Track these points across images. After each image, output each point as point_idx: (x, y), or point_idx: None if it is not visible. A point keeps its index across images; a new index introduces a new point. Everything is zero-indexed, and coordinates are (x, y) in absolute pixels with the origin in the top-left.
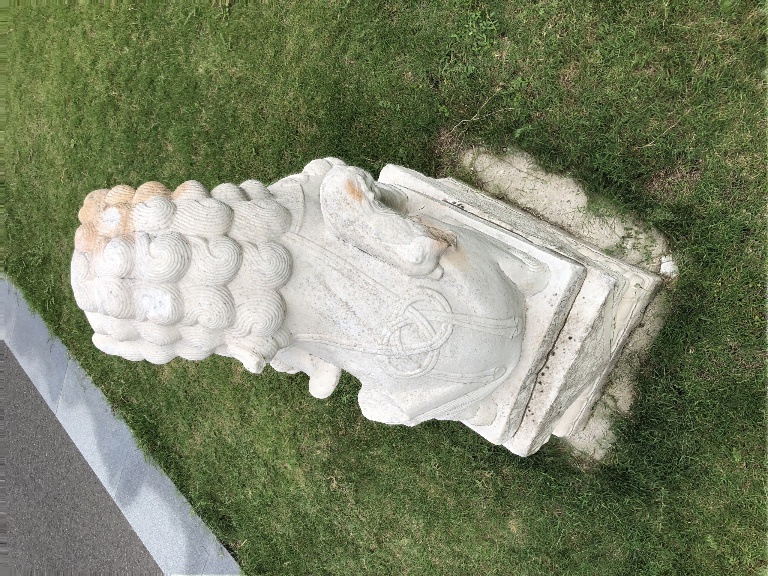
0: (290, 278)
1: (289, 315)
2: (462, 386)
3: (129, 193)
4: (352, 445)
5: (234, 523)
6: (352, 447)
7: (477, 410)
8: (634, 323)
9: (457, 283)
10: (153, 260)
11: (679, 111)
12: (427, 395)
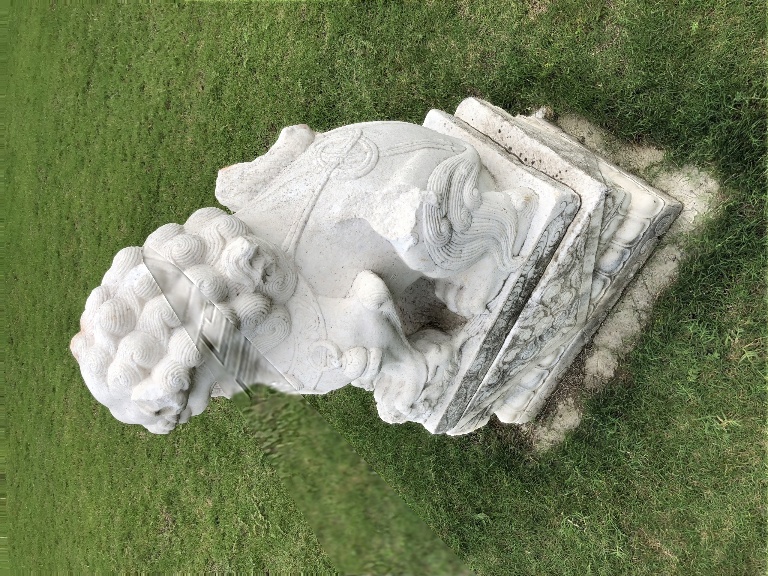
0: None
1: (254, 229)
2: None
3: None
4: (688, 573)
5: None
6: (692, 575)
7: (505, 193)
8: None
9: (339, 130)
10: (114, 262)
11: None
12: (406, 167)
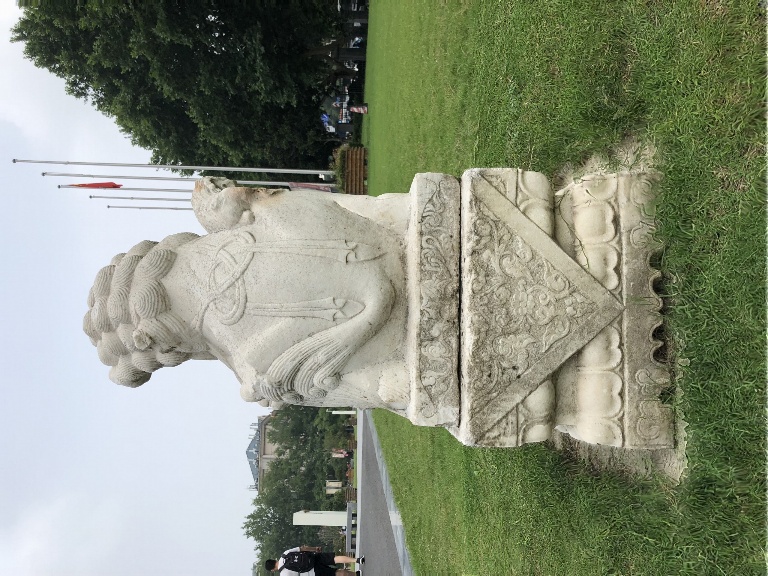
0: (170, 270)
1: (173, 301)
2: (292, 321)
3: None
4: None
5: None
6: None
7: (379, 378)
8: (644, 243)
9: (263, 219)
10: None
11: (609, 0)
12: (260, 338)
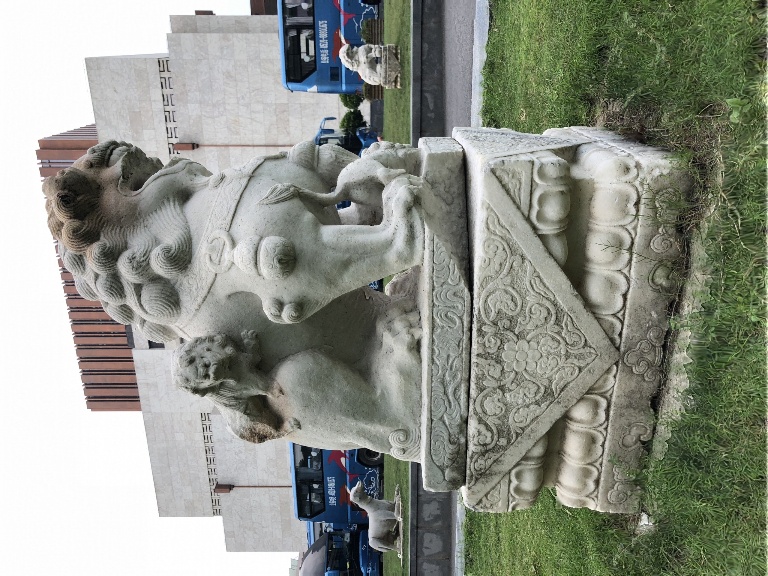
0: None
1: None
2: None
3: (62, 217)
4: None
5: (499, 4)
6: None
7: None
8: None
9: None
10: None
11: None
12: None
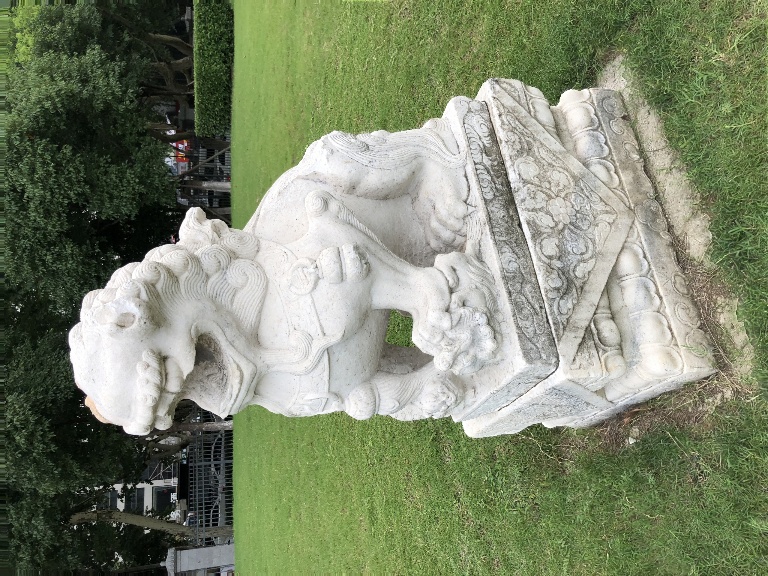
0: None
1: None
2: None
3: None
4: None
5: None
6: None
7: None
8: None
9: None
10: None
11: None
12: None
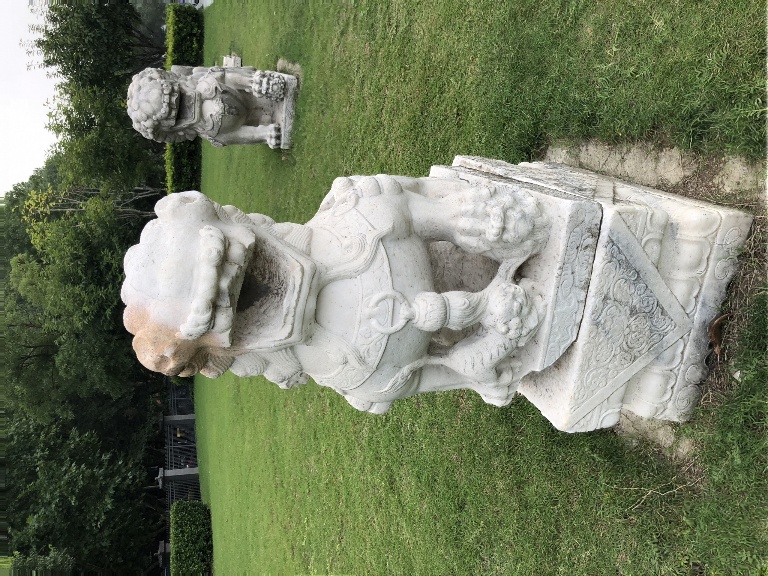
0: None
1: None
2: None
3: None
4: None
5: None
6: None
7: None
8: None
9: None
10: None
11: None
12: None
